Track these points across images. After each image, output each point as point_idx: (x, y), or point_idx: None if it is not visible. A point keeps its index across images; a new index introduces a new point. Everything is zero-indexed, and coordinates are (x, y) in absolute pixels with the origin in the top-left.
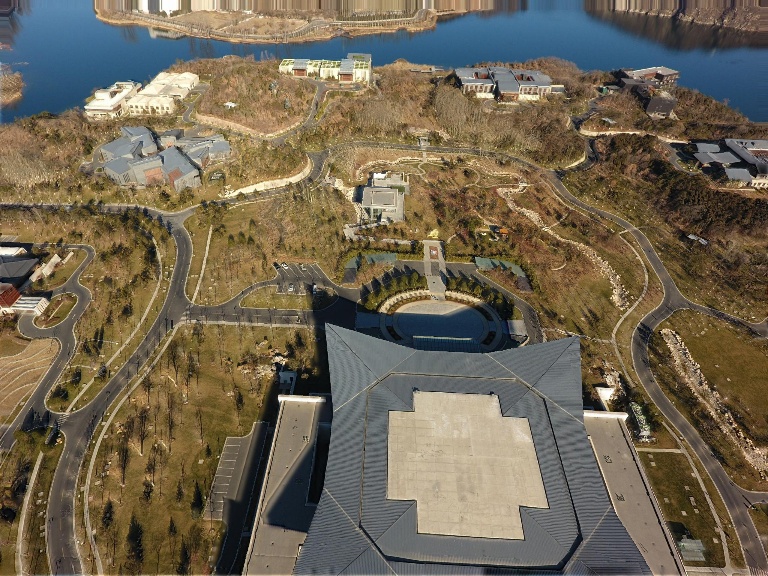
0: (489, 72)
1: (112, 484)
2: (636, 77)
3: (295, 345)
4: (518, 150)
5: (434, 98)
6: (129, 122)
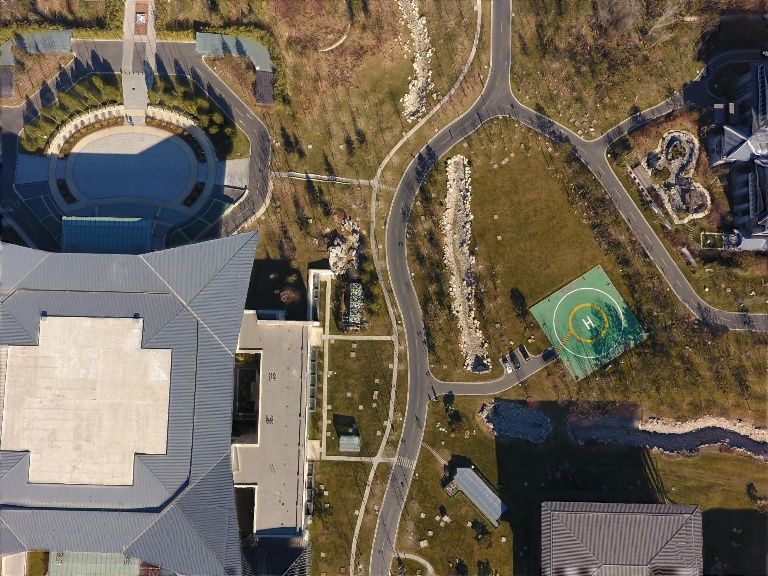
0: None
1: None
2: None
3: None
4: None
5: None
6: None
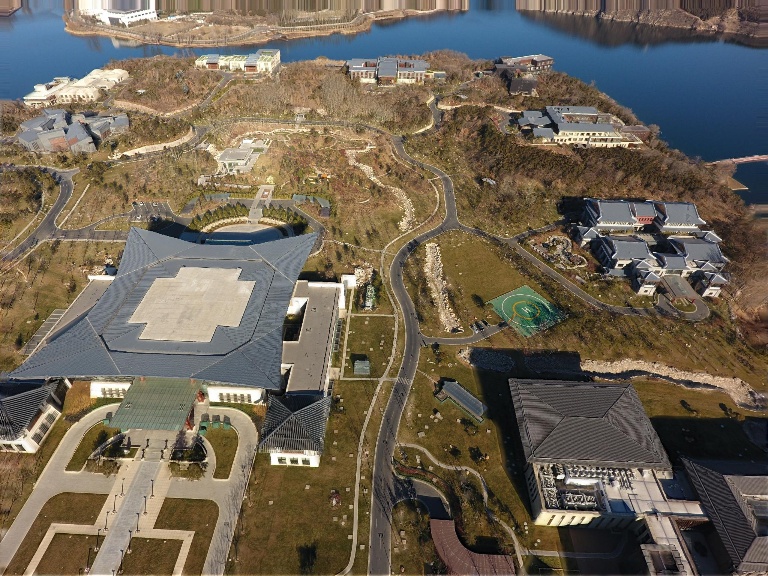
0: (377, 61)
1: None
2: (510, 63)
3: None
4: (379, 122)
5: (322, 83)
6: (54, 107)
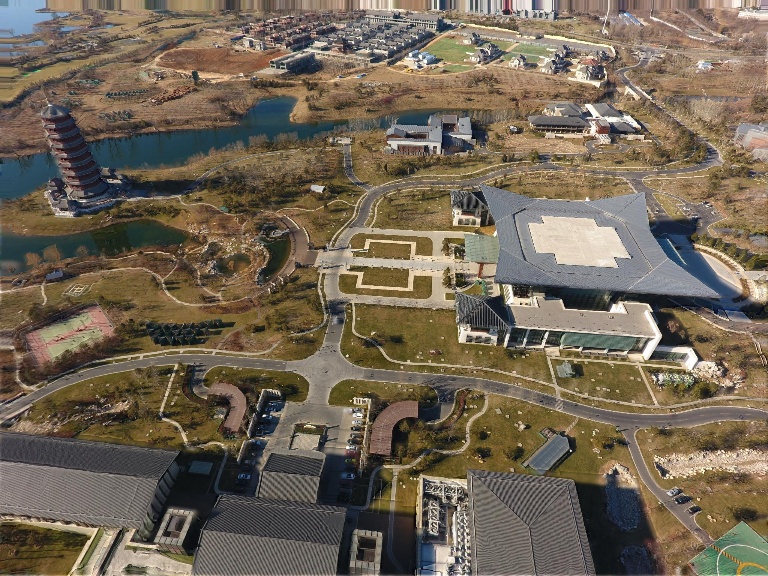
0: None
1: None
2: None
3: None
4: None
5: None
6: None
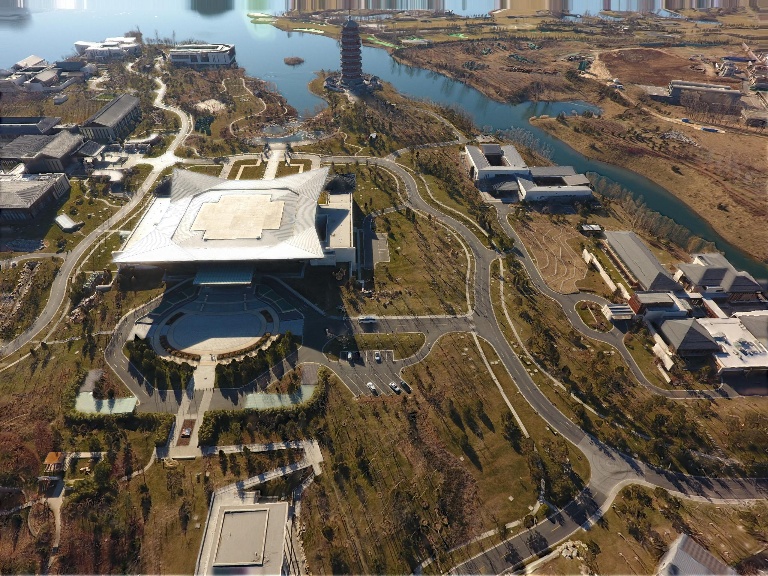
0: None
1: (441, 234)
2: None
3: (357, 302)
4: None
5: None
6: None
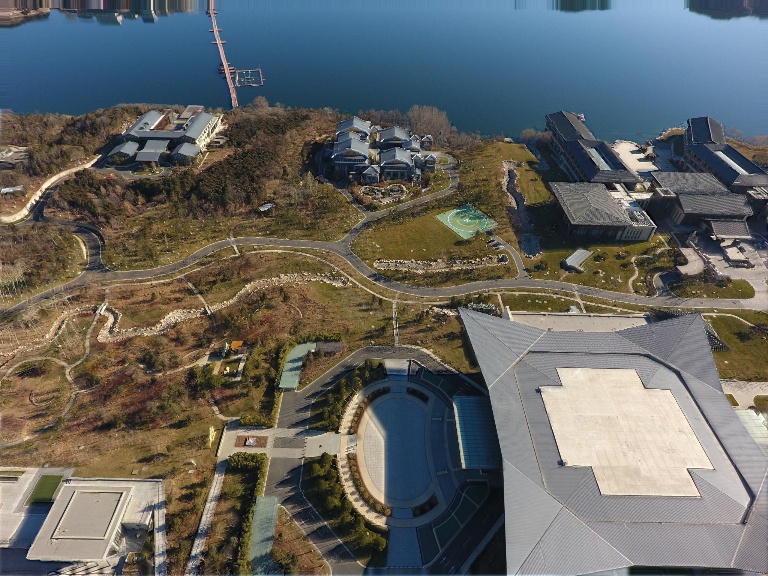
0: None
1: None
2: None
3: None
4: (2, 296)
5: None
6: None
